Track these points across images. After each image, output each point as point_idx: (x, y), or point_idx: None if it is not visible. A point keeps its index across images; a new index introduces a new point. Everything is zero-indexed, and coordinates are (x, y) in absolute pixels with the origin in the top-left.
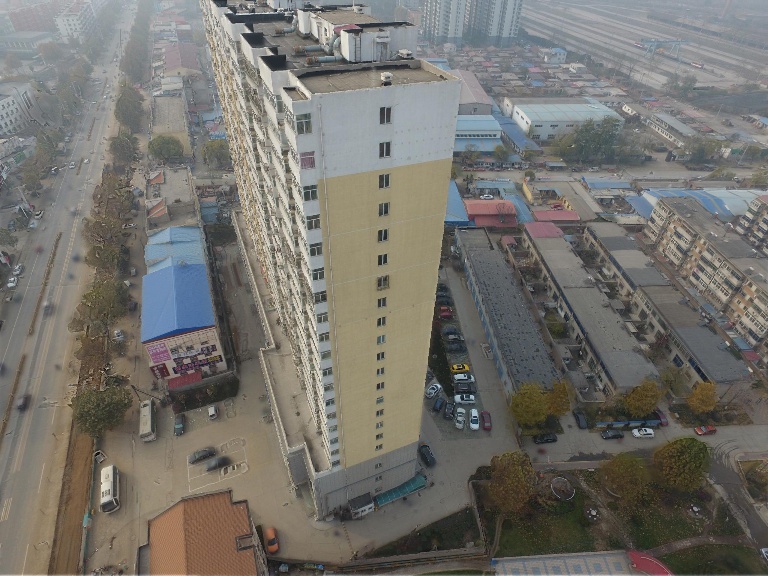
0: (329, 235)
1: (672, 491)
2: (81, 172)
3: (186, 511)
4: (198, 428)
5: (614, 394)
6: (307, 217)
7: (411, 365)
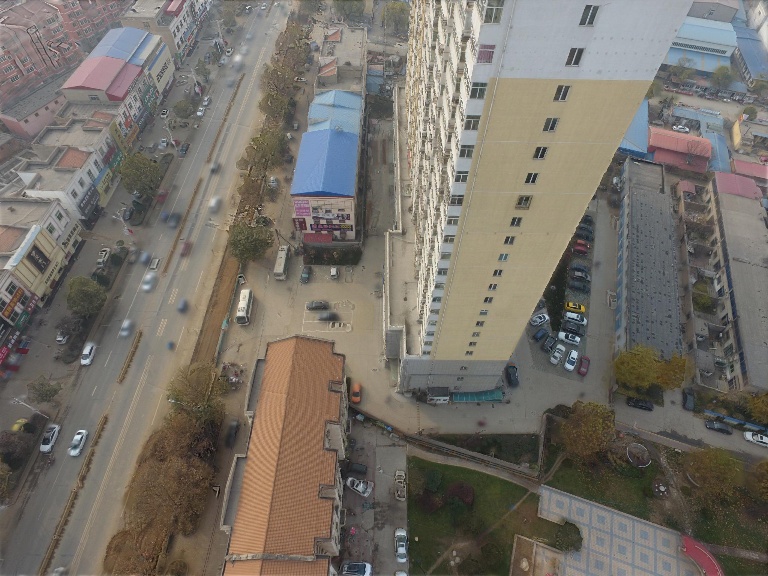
0: (484, 140)
1: (763, 505)
2: (270, 15)
3: (297, 346)
4: (320, 282)
5: (741, 389)
6: (467, 116)
7: (525, 290)
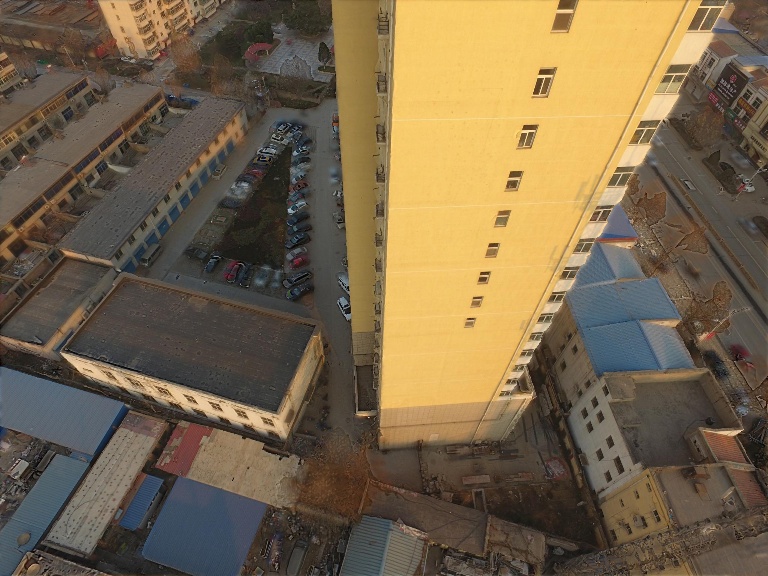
0: None
1: None
2: None
3: None
4: None
5: None
6: None
7: None
